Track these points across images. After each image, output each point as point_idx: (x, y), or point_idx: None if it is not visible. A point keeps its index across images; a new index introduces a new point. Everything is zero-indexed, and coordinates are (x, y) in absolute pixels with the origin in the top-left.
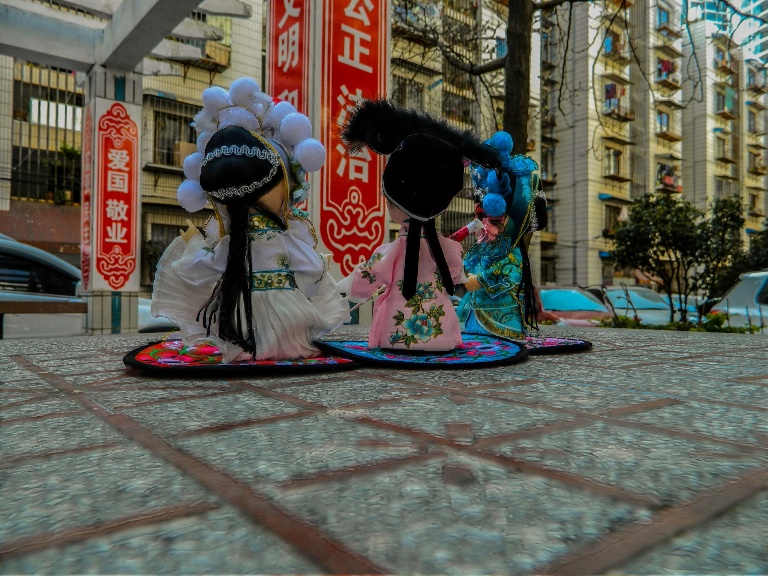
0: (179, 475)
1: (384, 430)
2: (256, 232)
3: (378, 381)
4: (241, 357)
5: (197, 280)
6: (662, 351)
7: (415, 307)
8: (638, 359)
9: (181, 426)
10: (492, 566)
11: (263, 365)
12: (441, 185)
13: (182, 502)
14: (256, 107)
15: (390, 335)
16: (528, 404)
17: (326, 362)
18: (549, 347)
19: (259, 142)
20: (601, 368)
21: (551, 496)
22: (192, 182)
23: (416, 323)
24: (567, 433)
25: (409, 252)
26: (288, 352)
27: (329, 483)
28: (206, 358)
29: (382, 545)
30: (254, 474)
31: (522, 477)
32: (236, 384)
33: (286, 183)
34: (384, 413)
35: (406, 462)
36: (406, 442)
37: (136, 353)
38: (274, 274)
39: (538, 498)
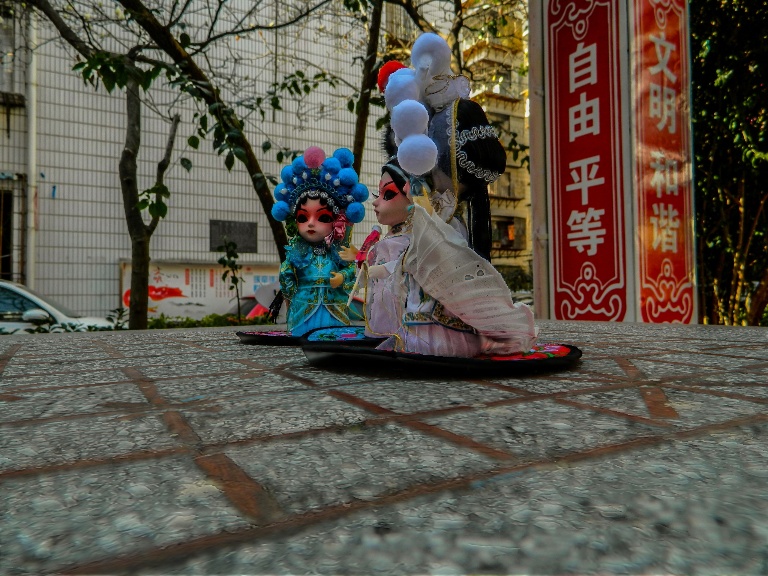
0: None
1: None
2: None
3: None
4: None
5: None
6: None
7: None
8: None
9: None
10: None
11: None
12: None
13: None
14: None
15: None
16: None
17: None
18: None
19: None
20: None
21: None
22: None
23: None
24: None
25: None
26: None
27: None
28: None
29: None
30: None
31: None
32: None
33: None
34: None
35: None
36: None
37: None
38: None
39: None
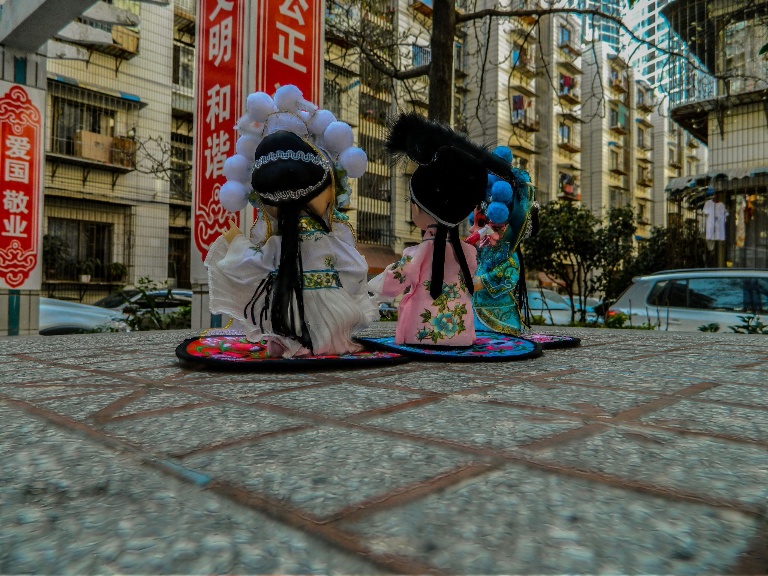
0: (416, 446)
1: (525, 409)
2: (304, 234)
3: (446, 372)
4: (300, 353)
5: (244, 279)
6: (641, 345)
7: (441, 306)
8: (633, 352)
9: (338, 411)
10: (754, 491)
11: (336, 359)
12: (469, 194)
13: (457, 464)
14: (299, 114)
15: (417, 332)
16: (606, 388)
17: (383, 356)
18: (552, 342)
19: (311, 149)
20: (615, 359)
21: (727, 449)
22: (235, 184)
23: (442, 321)
24: (670, 408)
25: (436, 255)
26: (338, 348)
27: (550, 447)
28: (250, 355)
29: (661, 483)
30: (477, 443)
31: (686, 438)
32: (320, 377)
33: (333, 188)
34: (500, 397)
35: (585, 431)
36: (559, 417)
37: (184, 350)
38: (323, 274)
39: (720, 451)
